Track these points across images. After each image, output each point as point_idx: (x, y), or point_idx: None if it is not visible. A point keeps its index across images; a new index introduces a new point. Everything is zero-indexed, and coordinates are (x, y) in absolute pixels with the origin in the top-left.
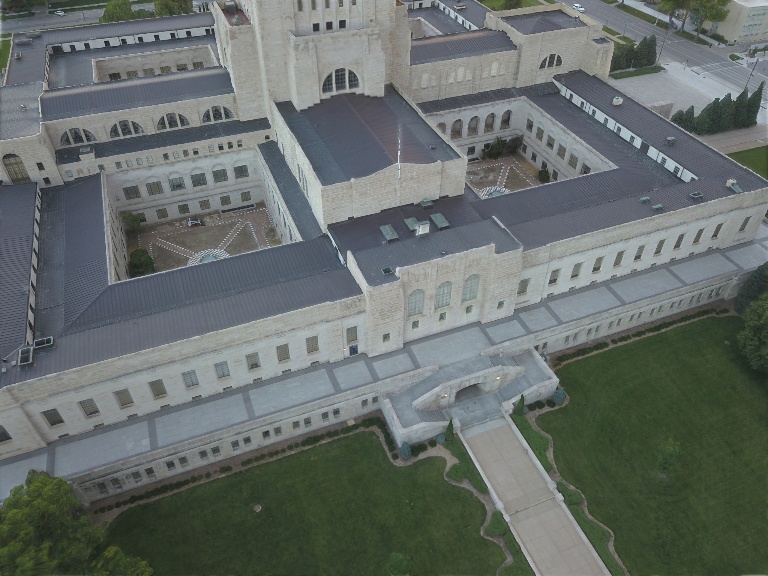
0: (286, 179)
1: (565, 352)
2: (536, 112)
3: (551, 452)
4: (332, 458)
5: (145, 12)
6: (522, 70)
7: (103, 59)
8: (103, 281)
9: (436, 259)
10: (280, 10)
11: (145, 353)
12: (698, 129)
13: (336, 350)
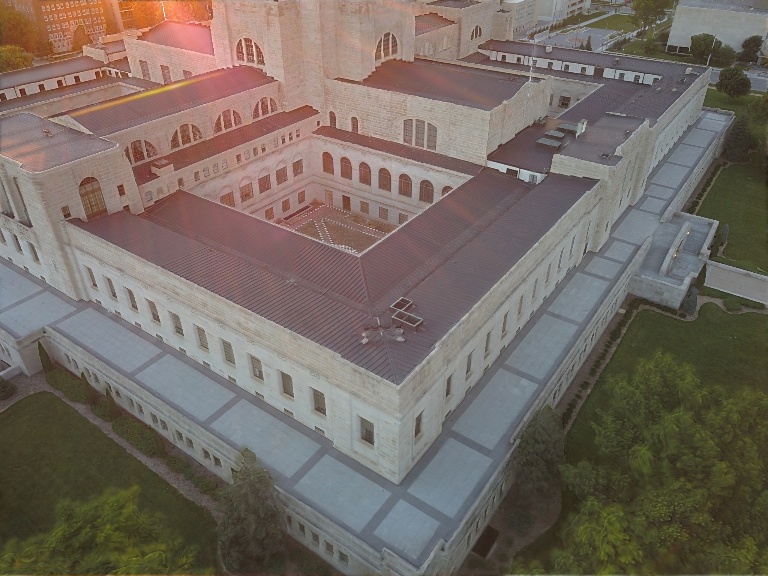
0: (383, 146)
1: None
2: None
3: (760, 269)
4: (645, 338)
5: None
6: (462, 42)
7: (1, 113)
8: (346, 257)
9: (631, 136)
10: None
11: (513, 272)
12: None
13: (582, 250)
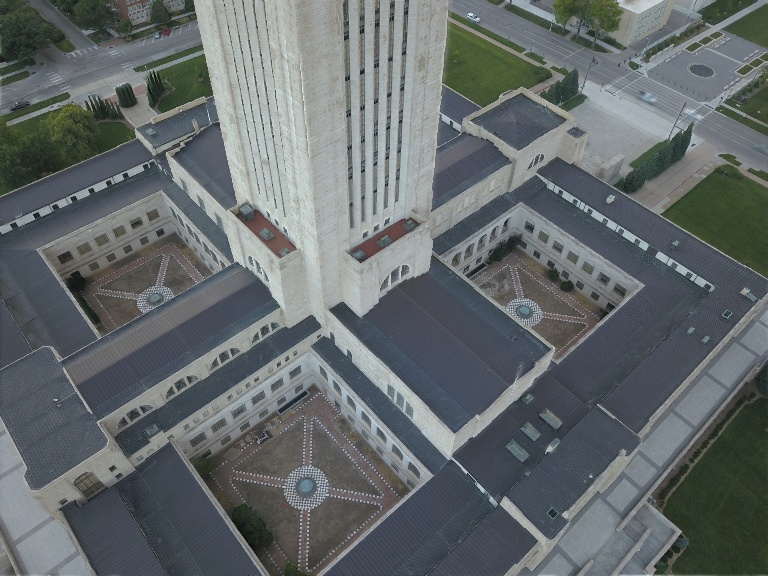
0: (369, 391)
1: (661, 487)
2: (538, 219)
3: None
4: None
5: (38, 137)
6: (515, 178)
7: (49, 245)
8: None
9: (590, 489)
10: (337, 239)
11: None
12: (648, 176)
13: None
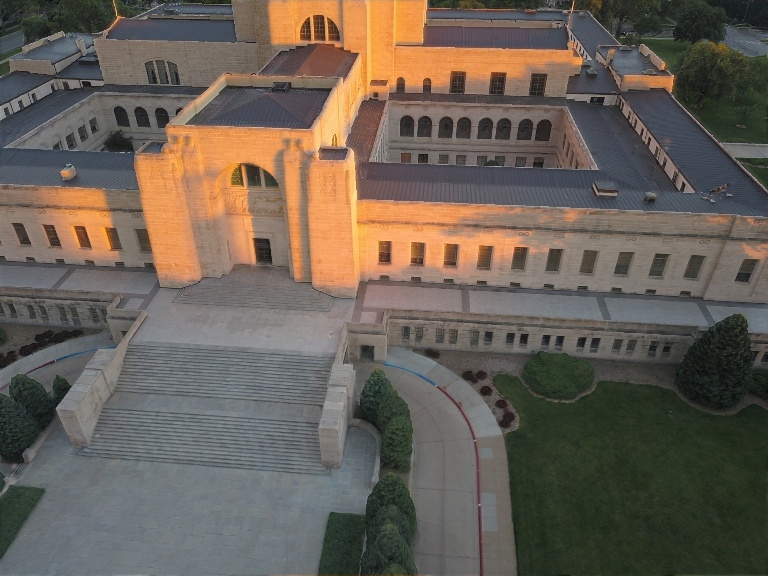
0: None
1: None
2: None
3: None
4: None
5: None
6: None
7: None
8: None
9: (48, 37)
10: None
11: None
12: None
13: None
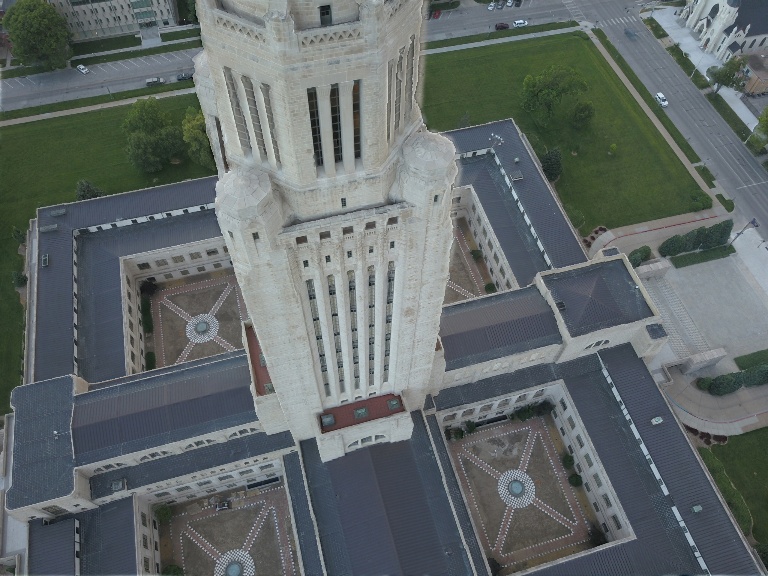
0: (307, 526)
1: None
2: None
3: None
4: None
5: (173, 132)
6: (564, 355)
7: (131, 257)
8: None
9: None
10: (307, 406)
11: None
12: (746, 383)
13: None
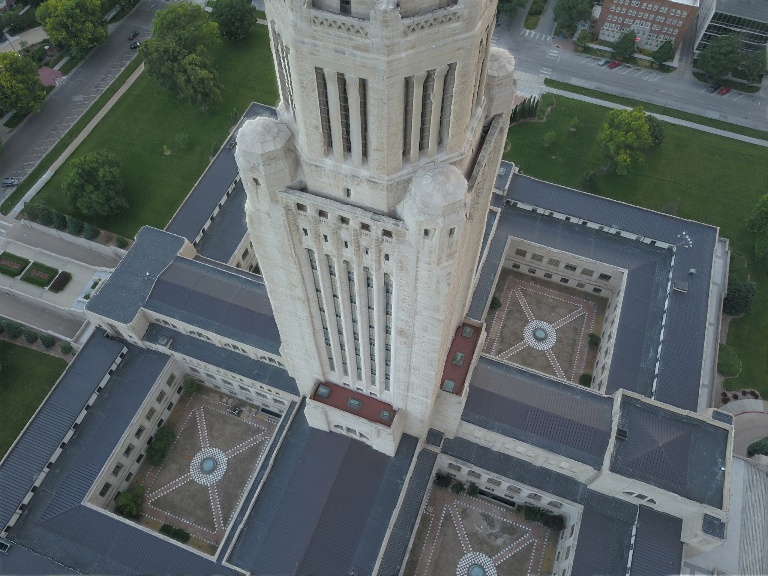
0: None
1: None
2: None
3: None
4: None
5: None
6: (597, 484)
7: None
8: (82, 495)
9: None
10: (310, 368)
11: None
12: None
13: None
